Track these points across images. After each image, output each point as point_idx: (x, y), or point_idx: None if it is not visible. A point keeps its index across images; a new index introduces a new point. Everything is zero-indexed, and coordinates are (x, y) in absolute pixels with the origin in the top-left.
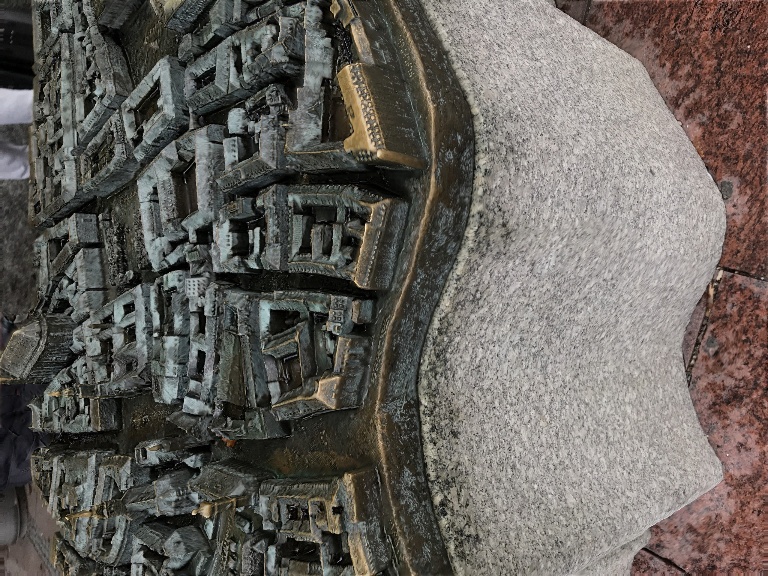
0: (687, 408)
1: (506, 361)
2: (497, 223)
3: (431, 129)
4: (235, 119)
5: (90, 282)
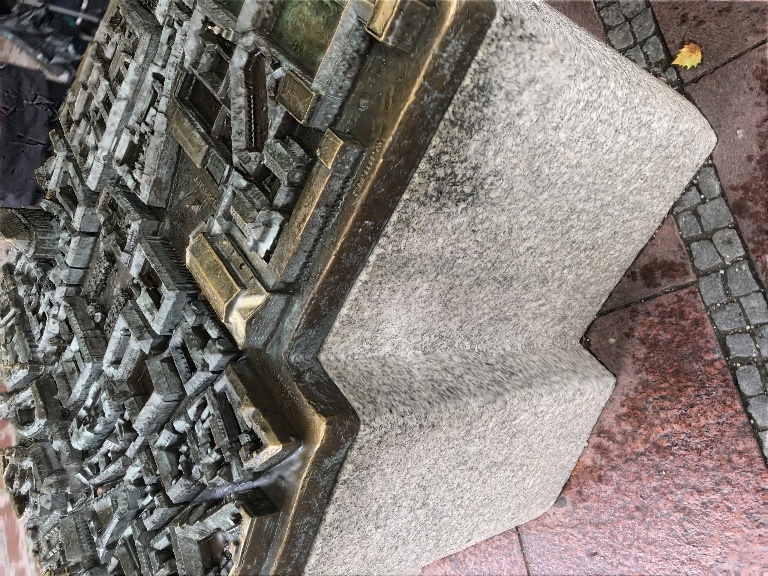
0: None
1: None
2: None
3: None
4: (180, 425)
5: (76, 263)
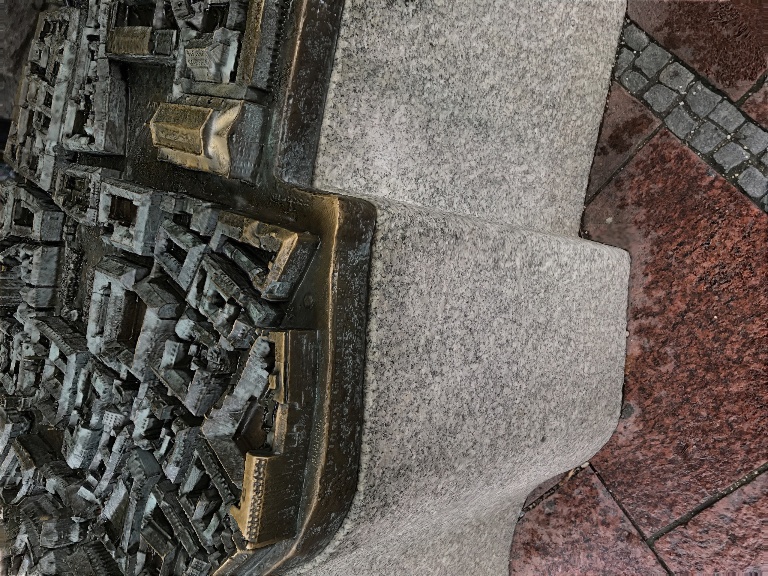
0: (505, 541)
1: (338, 569)
2: (347, 549)
3: (308, 516)
4: (183, 327)
5: (42, 280)
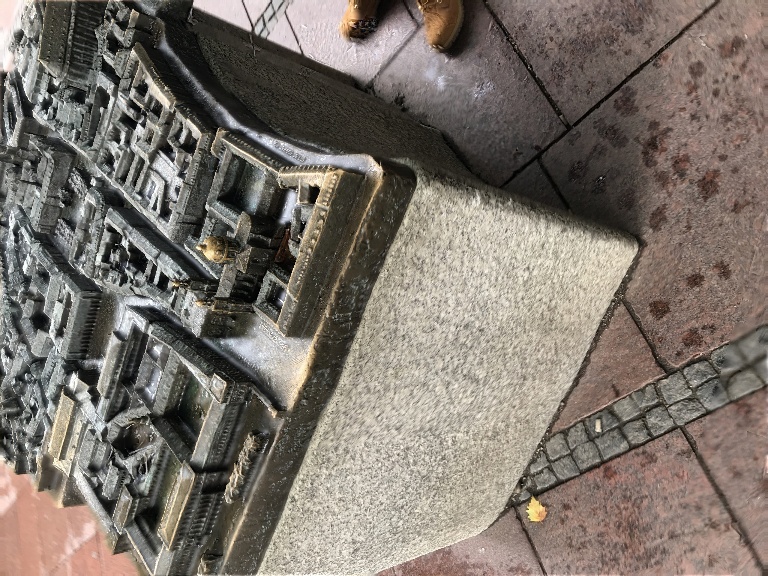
0: None
1: None
2: None
3: None
4: None
5: None
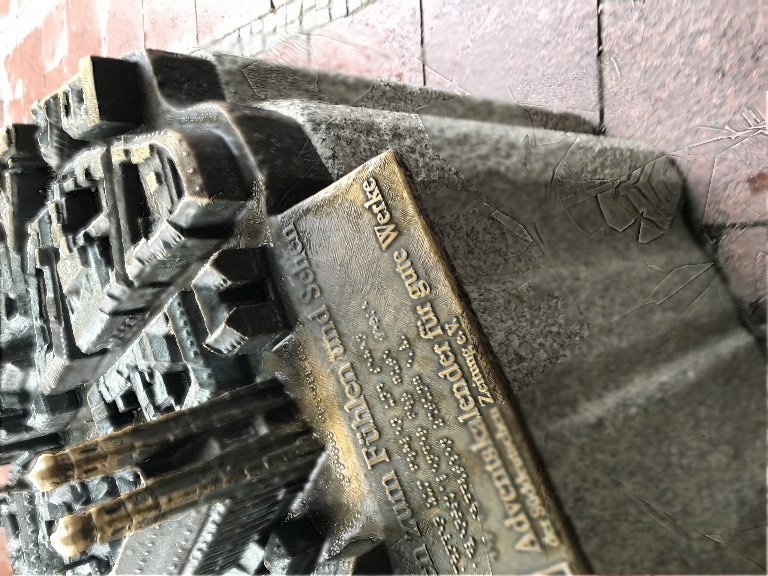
0: None
1: None
2: None
3: None
4: None
5: None
